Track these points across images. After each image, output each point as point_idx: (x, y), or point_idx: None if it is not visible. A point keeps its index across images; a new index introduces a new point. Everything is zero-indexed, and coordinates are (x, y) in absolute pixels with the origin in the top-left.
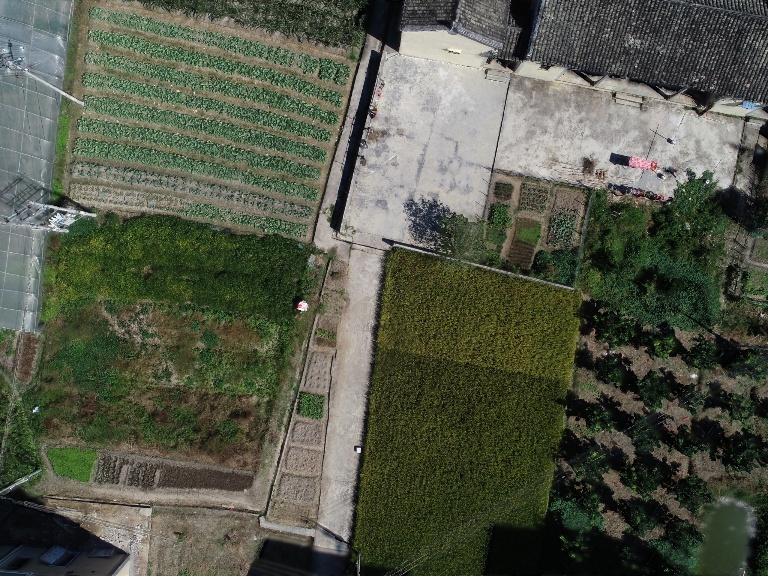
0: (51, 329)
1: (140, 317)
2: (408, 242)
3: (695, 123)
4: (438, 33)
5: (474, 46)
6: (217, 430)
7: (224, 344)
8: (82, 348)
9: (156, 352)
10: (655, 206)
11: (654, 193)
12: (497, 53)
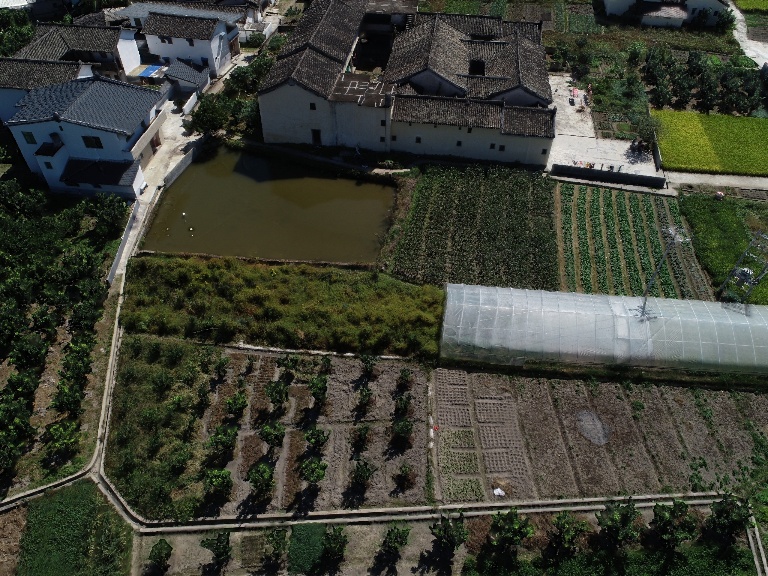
0: None
1: None
2: None
3: None
4: None
5: None
6: None
7: (765, 231)
8: None
9: None
10: None
11: None
12: None
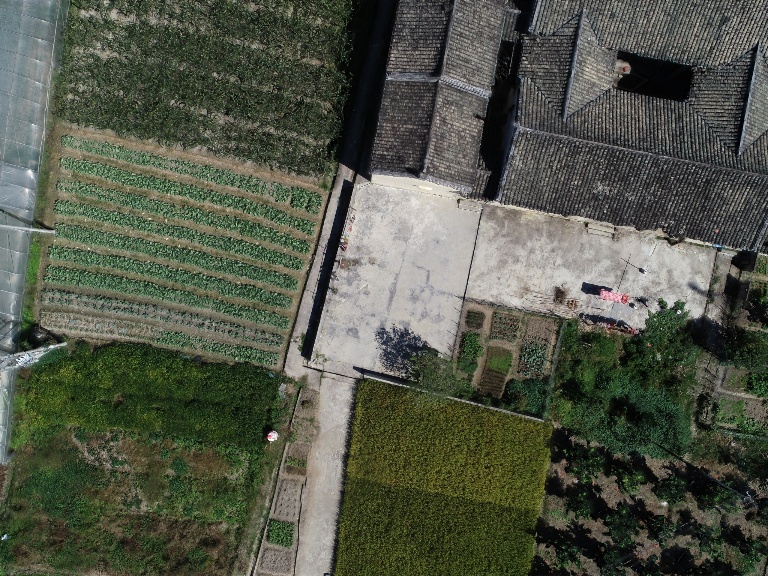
0: (20, 457)
1: (110, 444)
2: (379, 370)
3: (667, 253)
4: (407, 177)
5: (444, 187)
6: (186, 558)
7: (194, 472)
8: (51, 475)
9: (126, 479)
10: (626, 335)
11: (626, 322)
12: (467, 193)
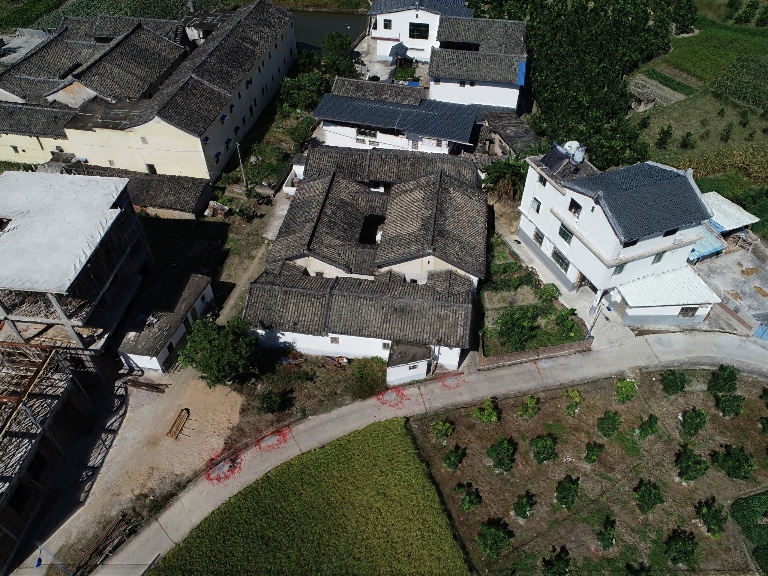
0: None
1: None
2: (4, 47)
3: None
4: None
5: None
6: None
7: None
8: None
9: (6, 6)
10: None
11: None
12: None
